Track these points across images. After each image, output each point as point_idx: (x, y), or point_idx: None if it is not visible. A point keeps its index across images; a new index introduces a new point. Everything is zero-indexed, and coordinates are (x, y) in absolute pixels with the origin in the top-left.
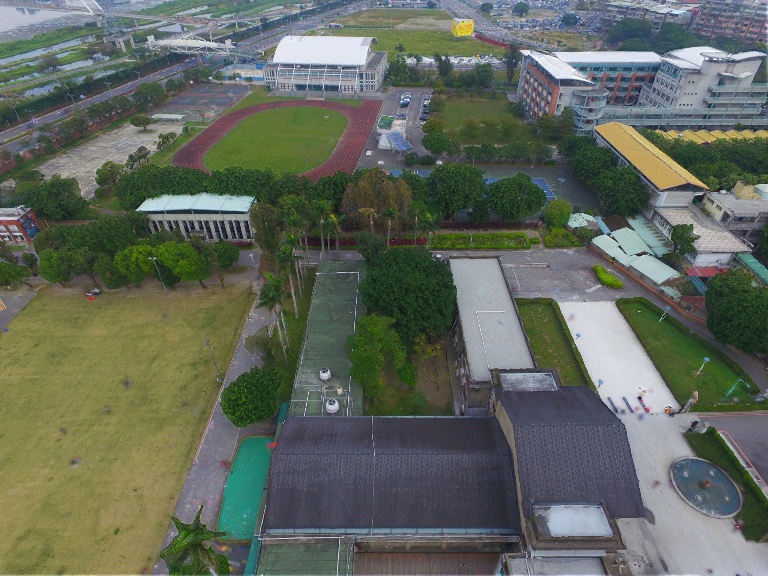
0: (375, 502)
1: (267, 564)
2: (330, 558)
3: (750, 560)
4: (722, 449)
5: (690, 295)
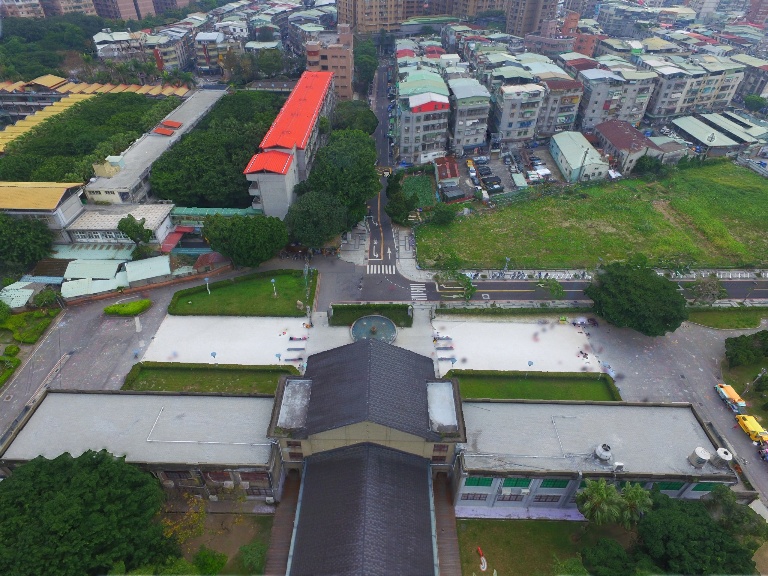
0: None
1: None
2: None
3: (423, 331)
4: (349, 309)
5: (194, 261)
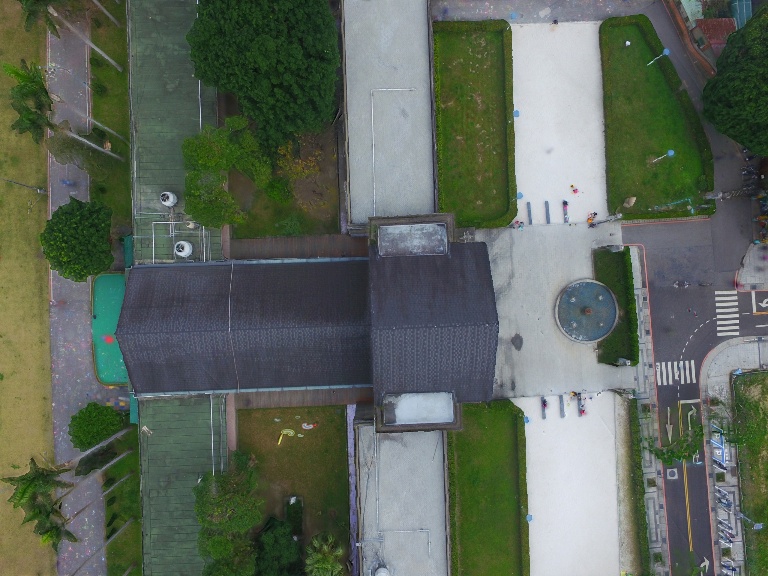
0: (238, 370)
1: (147, 417)
2: (204, 410)
3: (591, 379)
4: (624, 273)
5: (715, 15)
